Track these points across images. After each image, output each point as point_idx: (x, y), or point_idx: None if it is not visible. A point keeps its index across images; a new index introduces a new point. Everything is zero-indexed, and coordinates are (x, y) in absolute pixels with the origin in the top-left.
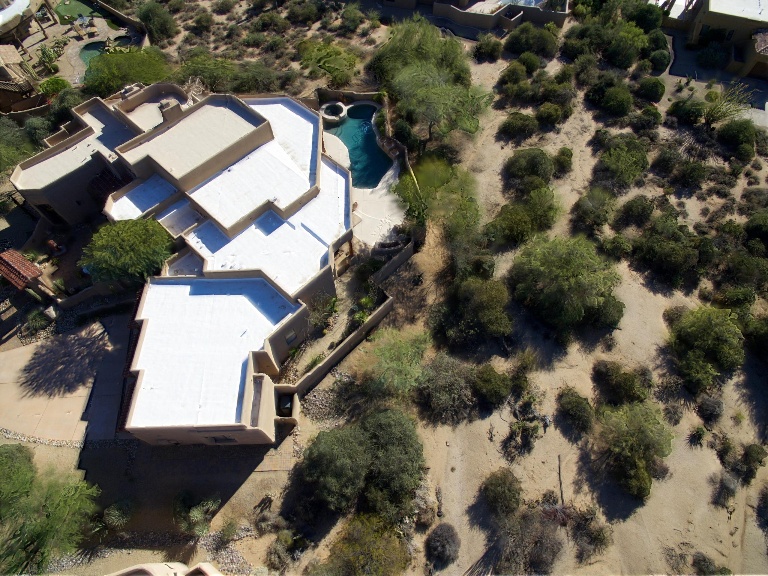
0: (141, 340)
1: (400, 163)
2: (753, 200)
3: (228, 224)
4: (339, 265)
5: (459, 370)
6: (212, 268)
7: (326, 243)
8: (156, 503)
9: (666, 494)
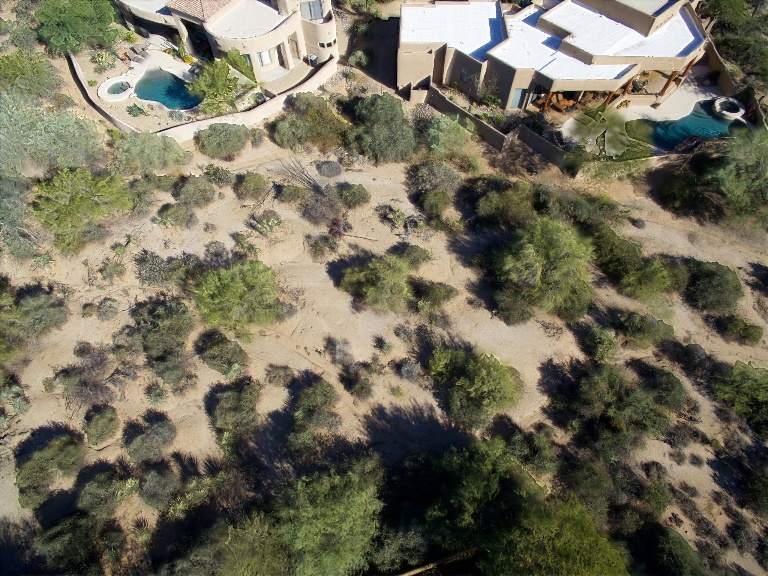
0: (455, 3)
1: (667, 152)
2: (733, 572)
3: (547, 20)
4: (536, 111)
5: (448, 186)
6: (510, 21)
7: (539, 71)
8: (369, 47)
9: (341, 304)
